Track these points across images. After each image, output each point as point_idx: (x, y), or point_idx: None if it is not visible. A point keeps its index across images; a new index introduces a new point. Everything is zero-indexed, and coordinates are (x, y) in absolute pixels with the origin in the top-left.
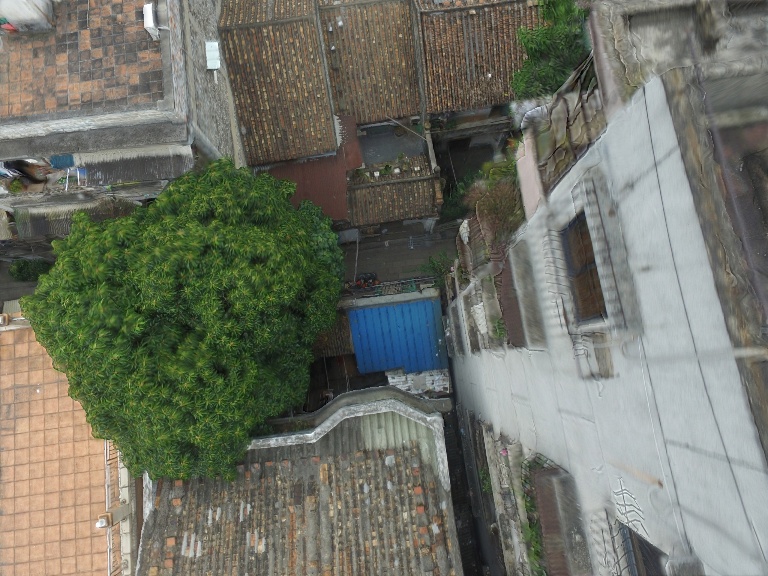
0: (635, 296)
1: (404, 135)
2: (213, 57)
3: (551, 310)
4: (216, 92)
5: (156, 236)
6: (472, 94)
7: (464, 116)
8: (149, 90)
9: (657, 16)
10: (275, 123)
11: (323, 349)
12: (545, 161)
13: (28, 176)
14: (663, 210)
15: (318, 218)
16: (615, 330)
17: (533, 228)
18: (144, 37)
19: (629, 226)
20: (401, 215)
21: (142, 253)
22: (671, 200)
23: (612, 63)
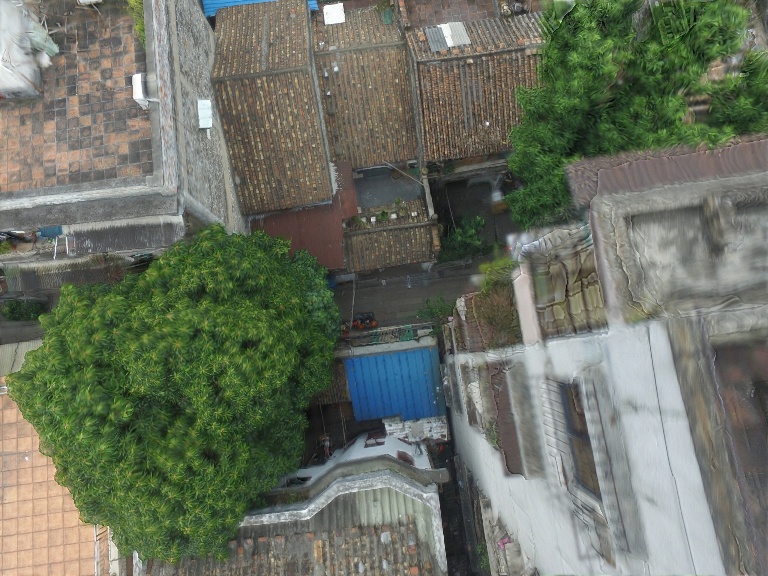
0: (639, 523)
1: (401, 178)
2: (205, 115)
3: (550, 461)
4: (209, 149)
5: (145, 318)
6: (470, 142)
7: (462, 160)
8: (139, 160)
9: (662, 213)
10: (270, 173)
11: (319, 397)
12: (543, 305)
13: (17, 236)
14: (670, 468)
15: (313, 270)
16: (618, 547)
17: (531, 357)
18: (134, 104)
19: (632, 448)
20: (398, 261)
21: (131, 333)
22: (679, 466)
23: (614, 275)
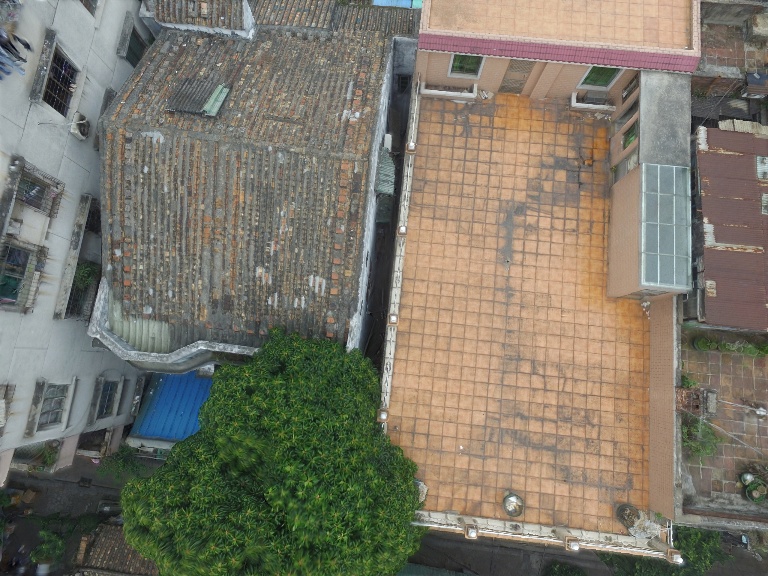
0: None
1: None
2: None
3: None
4: None
5: None
6: None
7: None
8: None
9: None
10: None
11: None
12: None
13: None
14: None
15: None
16: None
17: None
18: None
19: None
20: None
21: (264, 569)
22: None
23: None
